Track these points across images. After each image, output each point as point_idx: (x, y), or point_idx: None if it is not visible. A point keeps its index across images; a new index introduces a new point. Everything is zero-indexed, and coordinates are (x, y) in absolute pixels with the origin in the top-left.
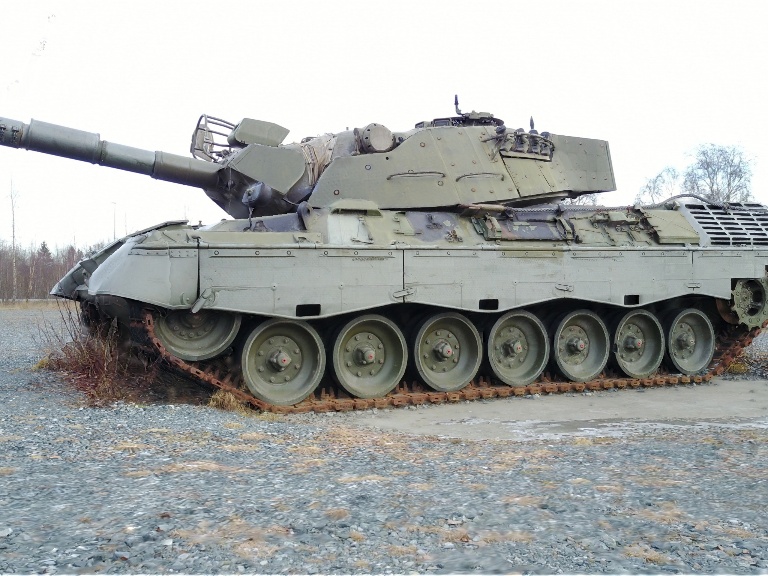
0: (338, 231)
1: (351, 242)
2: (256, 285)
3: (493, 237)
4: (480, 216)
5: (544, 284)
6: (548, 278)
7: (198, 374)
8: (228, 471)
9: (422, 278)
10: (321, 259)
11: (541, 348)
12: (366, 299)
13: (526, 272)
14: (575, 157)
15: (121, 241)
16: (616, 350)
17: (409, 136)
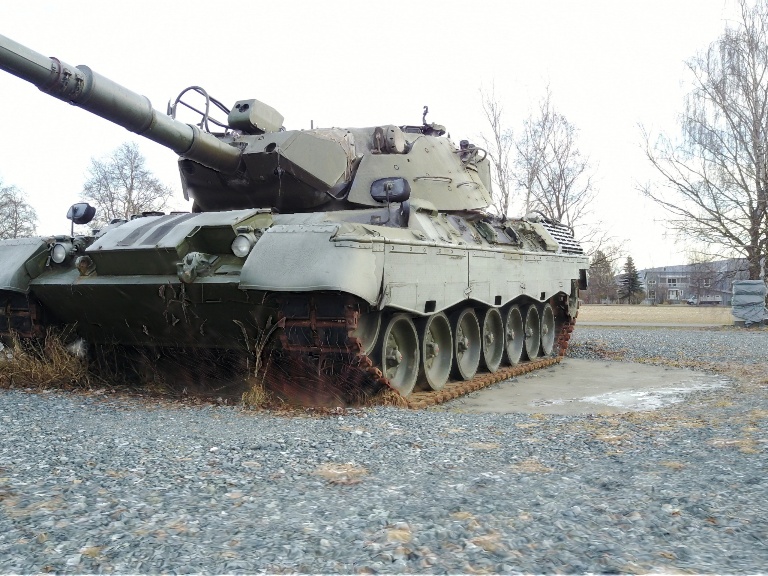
0: (429, 230)
1: (441, 241)
2: (409, 282)
3: (493, 240)
4: (476, 221)
5: (516, 283)
6: (518, 277)
7: (379, 374)
8: (762, 442)
9: (476, 276)
10: (437, 257)
11: (499, 338)
12: (454, 296)
13: (511, 272)
14: (478, 172)
15: (204, 228)
16: (526, 338)
17: (414, 141)
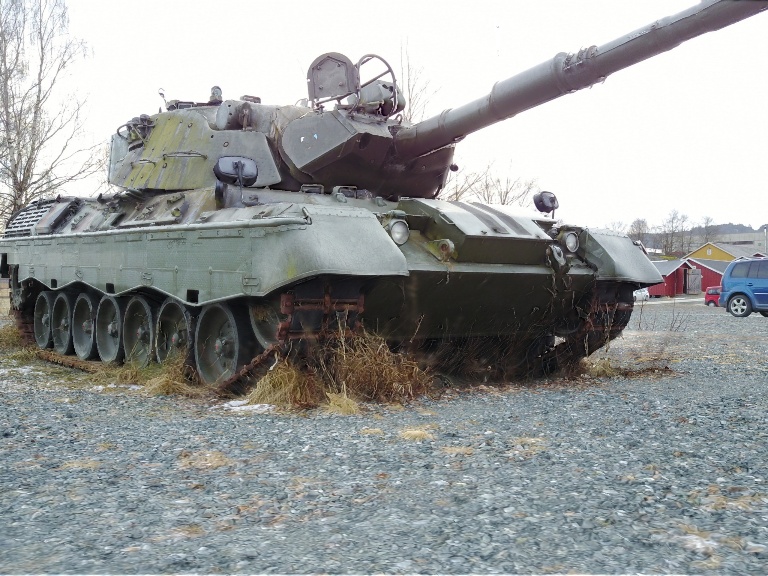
0: None
1: None
2: None
3: None
4: None
5: None
6: None
7: None
8: None
9: None
10: None
11: None
12: None
13: None
14: None
15: None
16: None
17: None
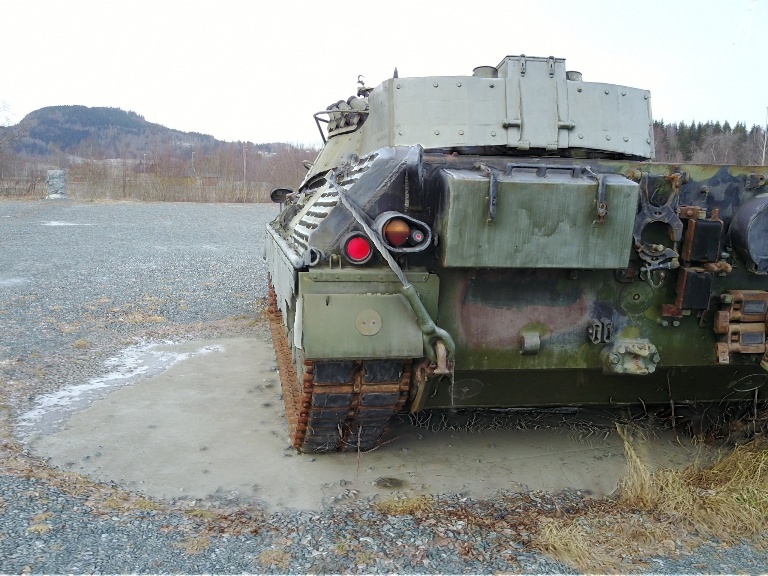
0: None
1: None
2: None
3: None
4: None
5: None
6: None
7: None
8: None
9: None
10: None
11: None
12: None
13: None
14: None
15: None
16: None
17: None
